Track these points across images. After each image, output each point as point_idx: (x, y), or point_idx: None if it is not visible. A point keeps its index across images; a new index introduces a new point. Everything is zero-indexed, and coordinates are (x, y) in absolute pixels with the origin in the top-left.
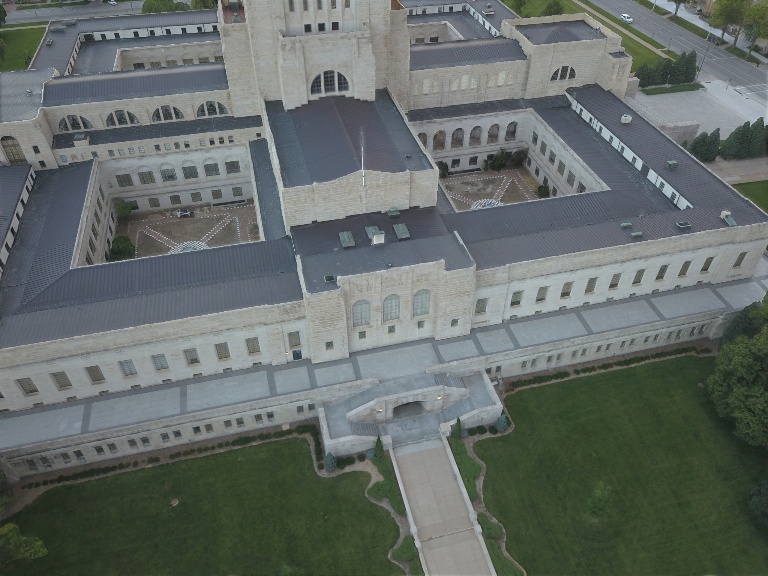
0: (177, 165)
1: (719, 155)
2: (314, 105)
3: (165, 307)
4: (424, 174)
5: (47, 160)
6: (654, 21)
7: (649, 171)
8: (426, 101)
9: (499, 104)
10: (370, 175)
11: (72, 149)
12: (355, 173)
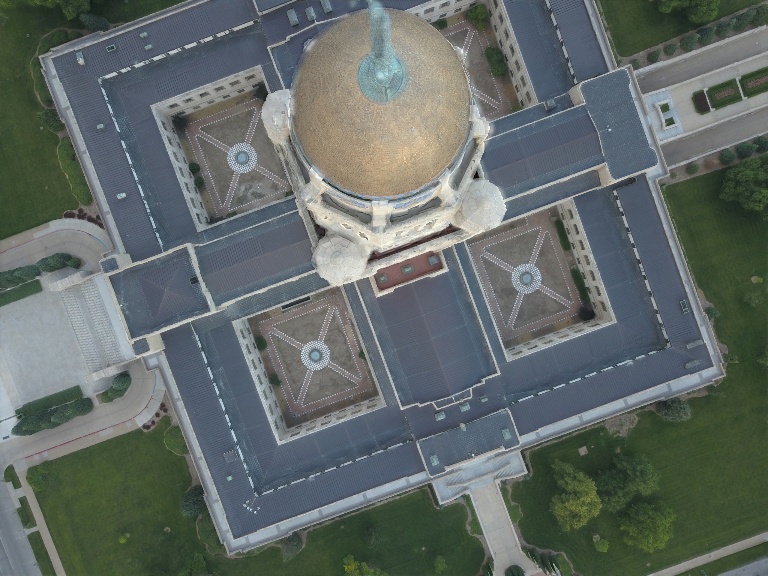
0: None
1: (41, 270)
2: None
3: None
4: None
5: None
6: None
7: None
8: None
9: None
10: None
11: (554, 98)
12: (321, 22)
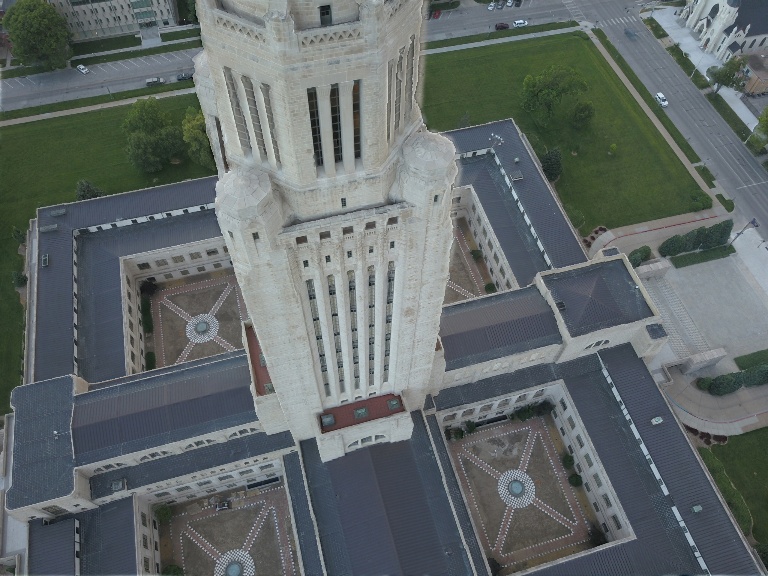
0: (213, 479)
1: None
2: (351, 459)
3: None
4: None
5: (88, 507)
6: (691, 102)
7: (674, 507)
8: (457, 383)
9: (530, 372)
10: None
11: (111, 496)
12: None
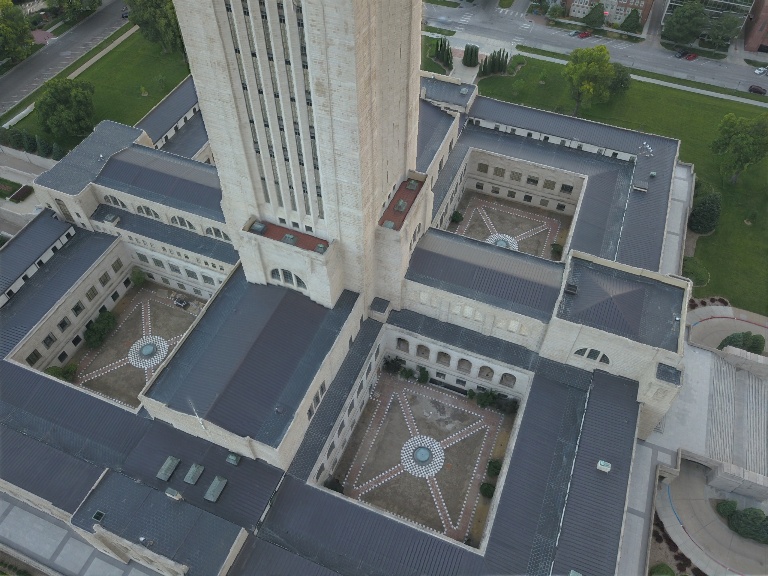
0: (180, 266)
1: None
2: (268, 290)
3: (3, 452)
4: (264, 447)
5: (86, 224)
6: None
7: None
8: (423, 309)
9: (505, 347)
10: (209, 426)
11: (103, 224)
12: (195, 418)
